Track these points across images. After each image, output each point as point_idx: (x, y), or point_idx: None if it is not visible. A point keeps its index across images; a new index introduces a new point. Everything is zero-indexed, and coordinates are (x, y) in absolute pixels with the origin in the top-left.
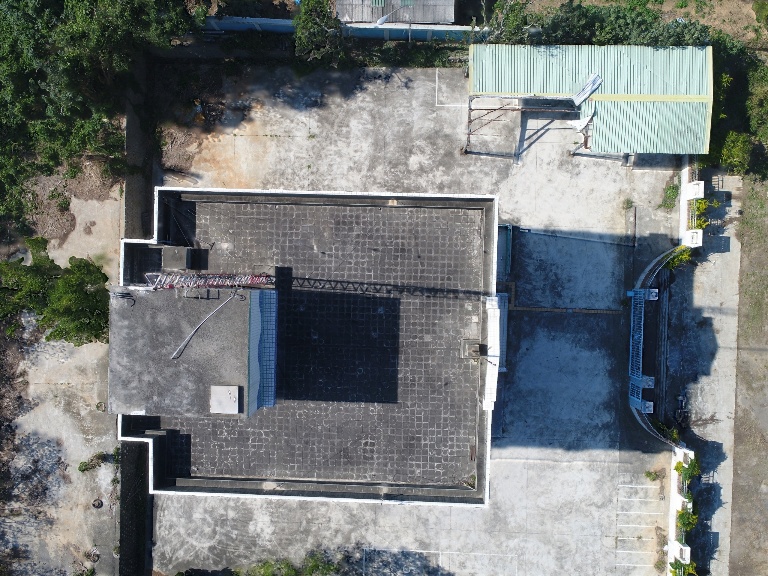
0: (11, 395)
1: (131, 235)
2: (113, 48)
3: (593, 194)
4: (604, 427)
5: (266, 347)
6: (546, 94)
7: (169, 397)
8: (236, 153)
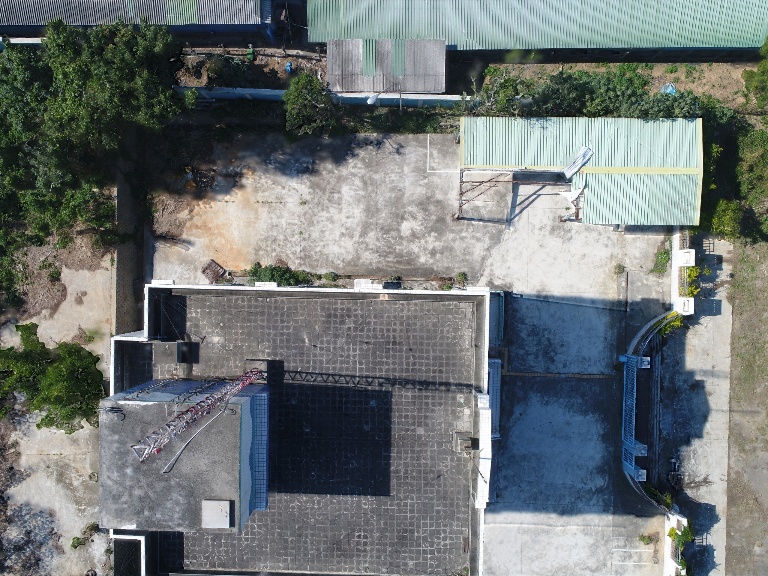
0: (3, 466)
1: (123, 304)
2: (102, 128)
3: (585, 259)
4: (598, 491)
5: (258, 450)
6: (537, 167)
7: (160, 511)
8: (228, 219)
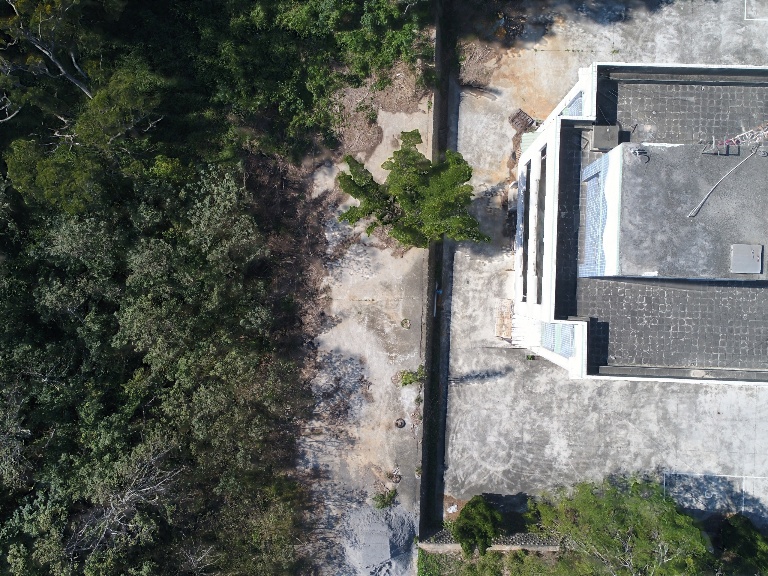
0: (314, 311)
1: (434, 150)
2: None
3: None
4: None
5: None
6: None
7: (684, 257)
8: (536, 68)
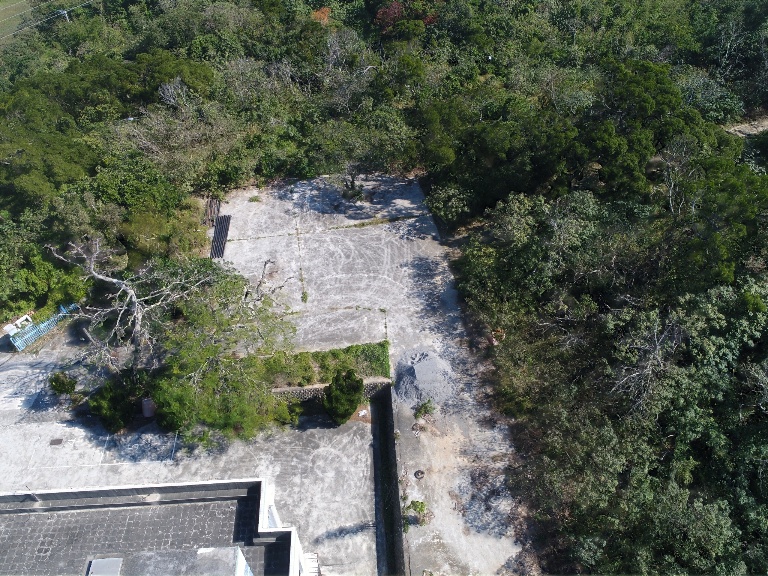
0: None
1: None
2: None
3: None
4: None
5: None
6: None
7: (168, 572)
8: None
